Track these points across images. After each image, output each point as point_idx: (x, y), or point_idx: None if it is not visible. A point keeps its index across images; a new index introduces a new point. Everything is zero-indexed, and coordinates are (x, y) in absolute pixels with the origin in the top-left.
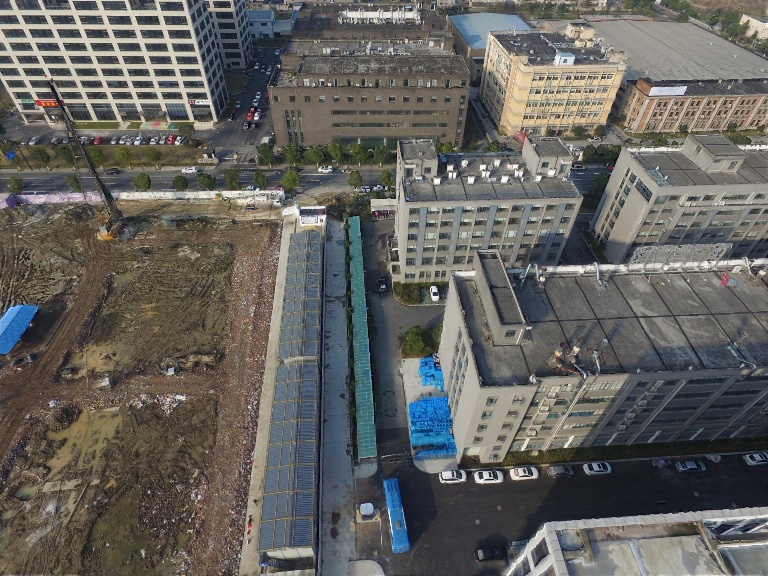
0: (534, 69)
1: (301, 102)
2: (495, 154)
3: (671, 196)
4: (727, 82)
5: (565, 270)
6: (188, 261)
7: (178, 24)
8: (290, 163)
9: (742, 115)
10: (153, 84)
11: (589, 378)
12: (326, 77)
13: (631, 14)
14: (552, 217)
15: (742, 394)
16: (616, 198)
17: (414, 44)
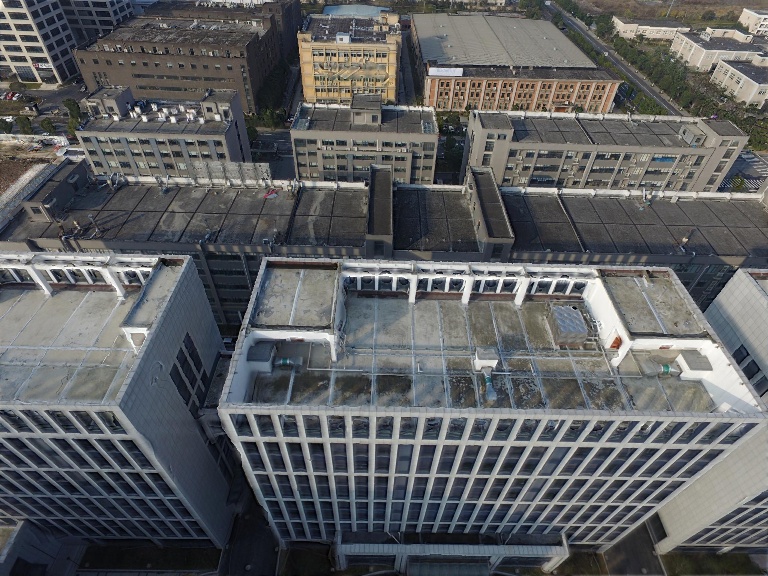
0: (311, 45)
1: (104, 65)
2: (194, 103)
3: (308, 140)
4: (518, 68)
5: (146, 180)
6: None
7: None
8: None
9: (526, 98)
10: None
11: (72, 242)
12: (121, 43)
13: (508, 12)
14: (209, 152)
15: (232, 274)
16: None
17: (243, 24)
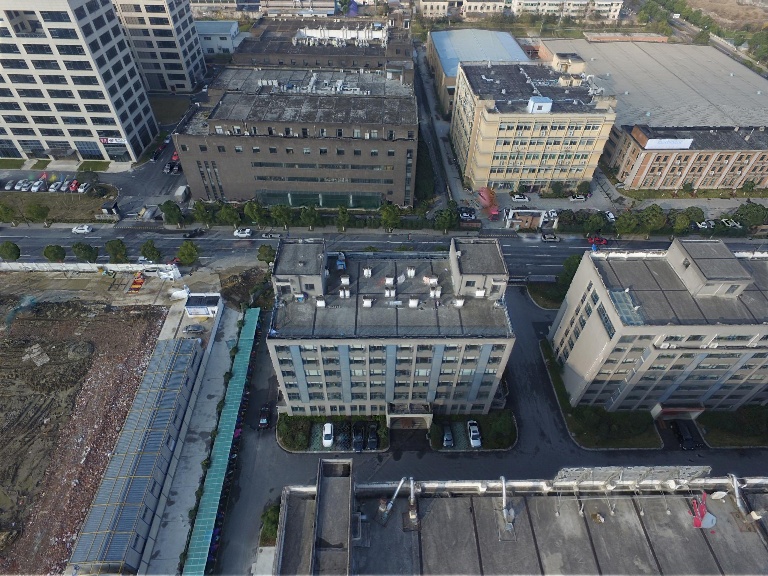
0: (500, 117)
1: (214, 152)
2: (415, 254)
3: (642, 335)
4: (745, 130)
5: (458, 485)
6: (31, 369)
7: (74, 54)
8: (203, 222)
9: (761, 172)
10: (56, 120)
11: None
12: (242, 124)
13: (643, 31)
14: (476, 357)
15: None
16: (576, 313)
17: (371, 74)
